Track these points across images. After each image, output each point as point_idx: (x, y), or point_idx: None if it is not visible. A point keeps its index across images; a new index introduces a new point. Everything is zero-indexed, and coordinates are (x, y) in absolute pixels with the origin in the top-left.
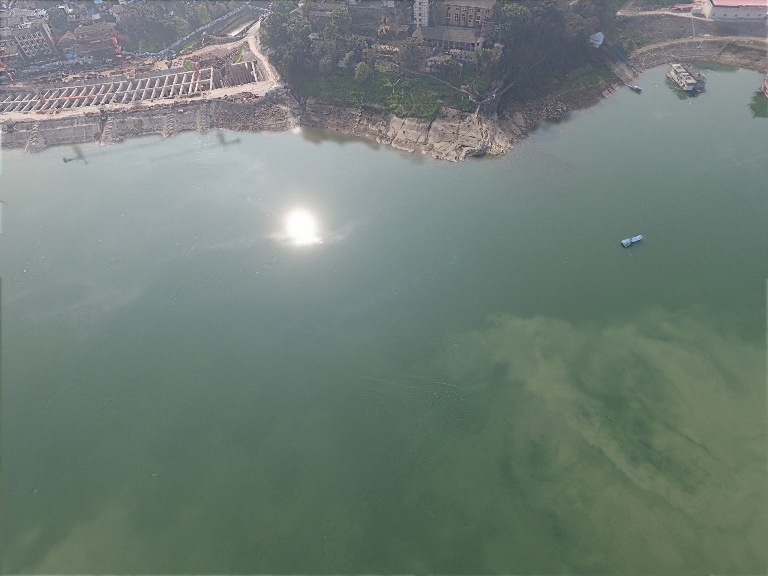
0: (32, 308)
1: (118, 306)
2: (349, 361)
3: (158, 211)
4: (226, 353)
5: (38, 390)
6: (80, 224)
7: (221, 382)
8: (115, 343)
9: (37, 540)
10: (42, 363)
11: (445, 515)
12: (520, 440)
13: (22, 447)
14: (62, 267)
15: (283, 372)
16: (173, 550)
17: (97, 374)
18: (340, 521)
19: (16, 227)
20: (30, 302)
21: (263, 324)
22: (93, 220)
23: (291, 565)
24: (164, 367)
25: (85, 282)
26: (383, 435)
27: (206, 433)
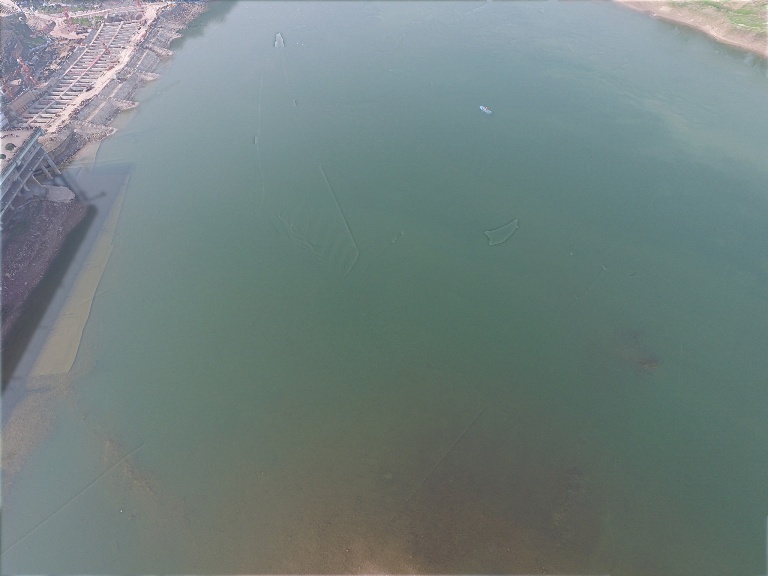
0: (328, 32)
1: (329, 25)
2: None
3: None
4: None
5: (374, 23)
6: (262, 42)
7: None
8: (354, 14)
9: None
10: None
11: None
12: None
13: None
14: (300, 35)
15: None
16: (431, 3)
17: (369, 14)
18: None
19: (254, 57)
20: None
21: None
22: (260, 40)
23: None
24: (369, 4)
25: None
26: None
27: (396, 0)
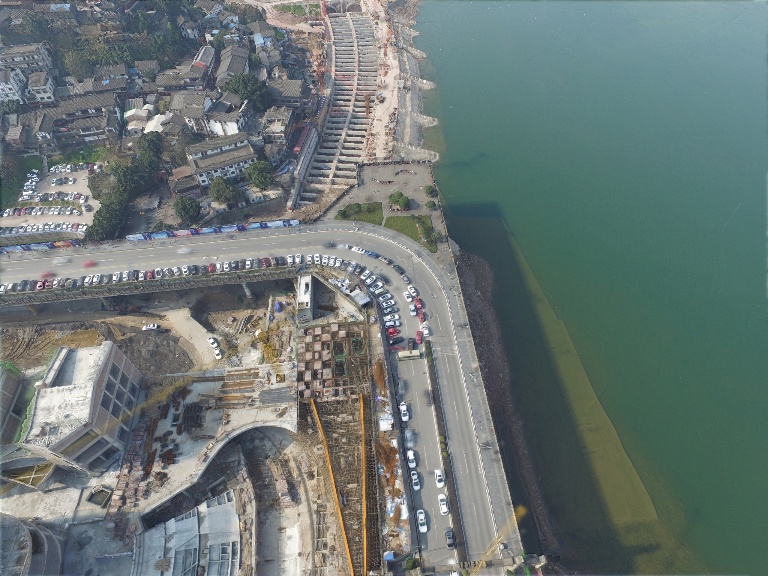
0: (600, 40)
1: None
2: None
3: (508, 26)
4: (600, 5)
5: (643, 31)
6: (524, 48)
7: None
8: (610, 19)
9: None
10: (629, 33)
11: None
12: None
13: (669, 26)
14: (566, 42)
15: None
16: None
17: (628, 20)
18: None
19: (532, 67)
20: (595, 44)
21: None
22: (519, 44)
23: None
24: None
25: (572, 37)
26: None
27: None
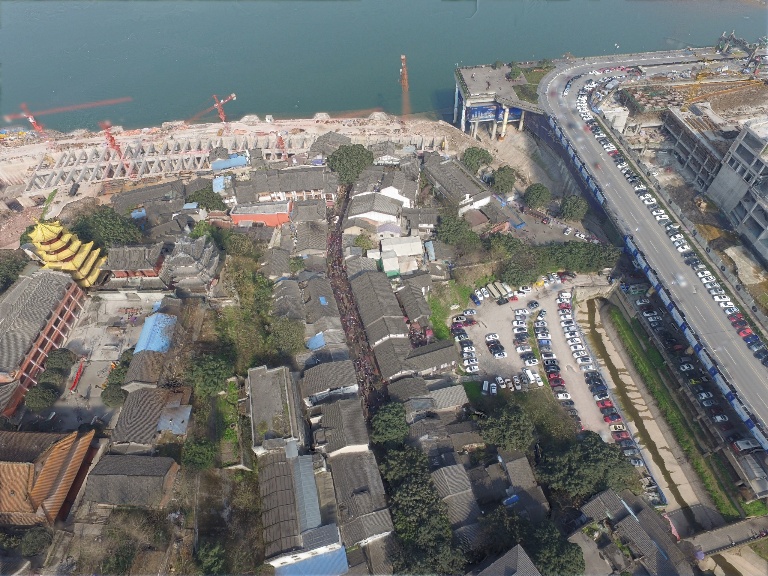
0: (204, 30)
1: None
2: (61, 21)
3: None
4: (115, 28)
5: None
6: (191, 67)
7: (117, 16)
8: (161, 23)
9: (191, 1)
10: (194, 19)
11: (60, 4)
12: (17, 4)
13: None
14: (194, 45)
15: (90, 18)
16: None
17: (168, 16)
18: (94, 5)
19: (235, 65)
20: (207, 34)
21: (93, 33)
22: (182, 69)
23: (113, 0)
24: (139, 17)
25: (182, 44)
26: (65, 13)
27: None
